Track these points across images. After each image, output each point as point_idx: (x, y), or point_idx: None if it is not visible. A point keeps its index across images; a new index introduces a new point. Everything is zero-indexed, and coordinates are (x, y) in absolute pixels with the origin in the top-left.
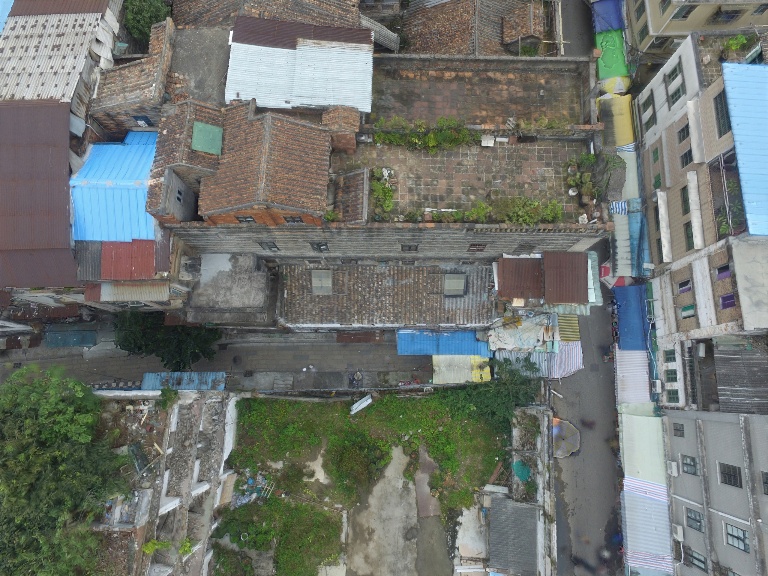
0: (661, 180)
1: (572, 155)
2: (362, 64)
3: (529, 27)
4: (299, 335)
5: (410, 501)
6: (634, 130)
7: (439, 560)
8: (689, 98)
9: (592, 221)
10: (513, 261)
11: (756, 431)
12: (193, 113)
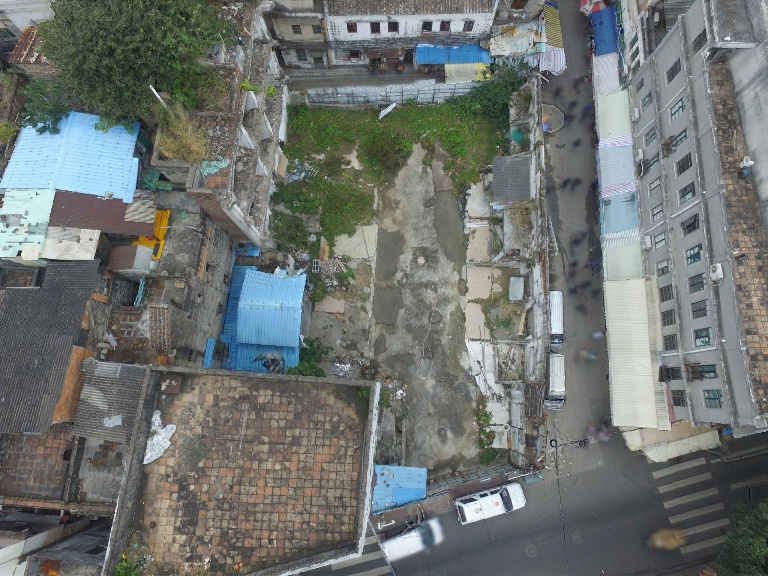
0: None
1: None
2: None
3: None
4: (334, 71)
5: (428, 181)
6: None
7: (452, 221)
8: None
9: None
10: None
11: (689, 18)
12: None
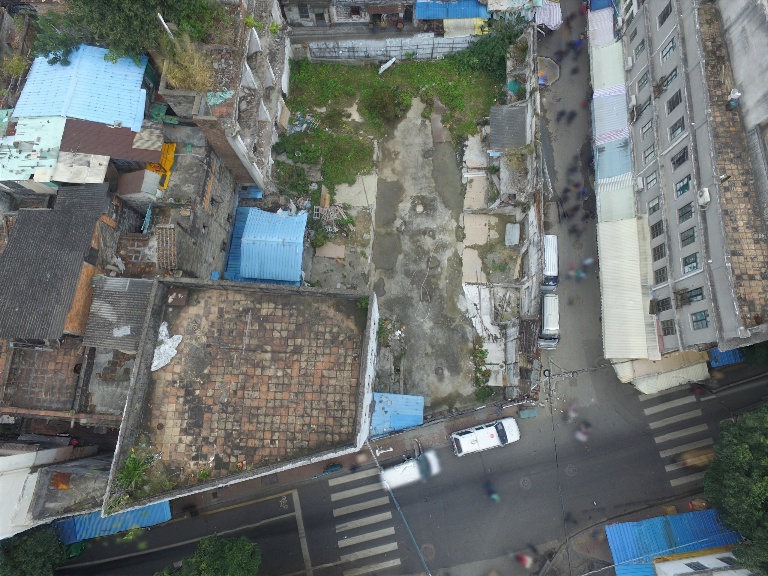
0: None
1: None
2: None
3: None
4: (335, 29)
5: (427, 133)
6: None
7: (450, 171)
8: None
9: None
10: None
11: None
12: None
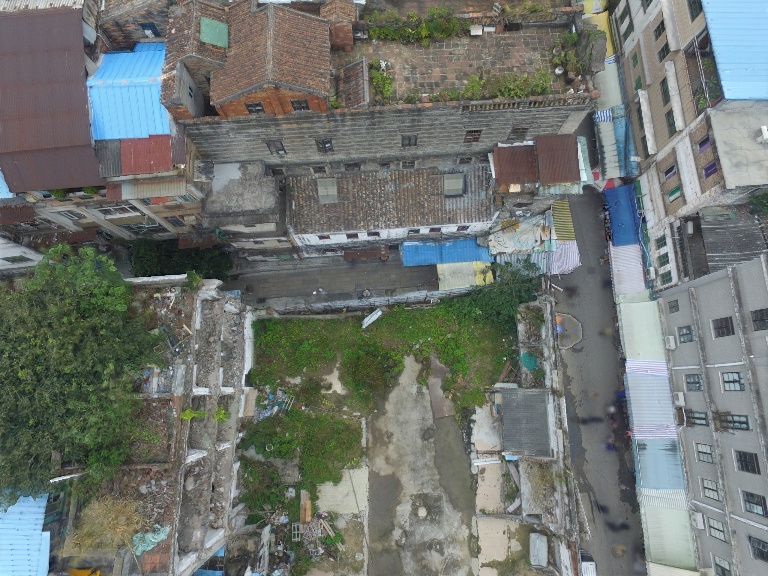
0: (641, 81)
1: None
2: None
3: None
4: (307, 261)
5: (425, 404)
6: (613, 43)
7: (456, 456)
8: None
9: (579, 92)
10: (507, 149)
11: (743, 277)
12: (199, 11)
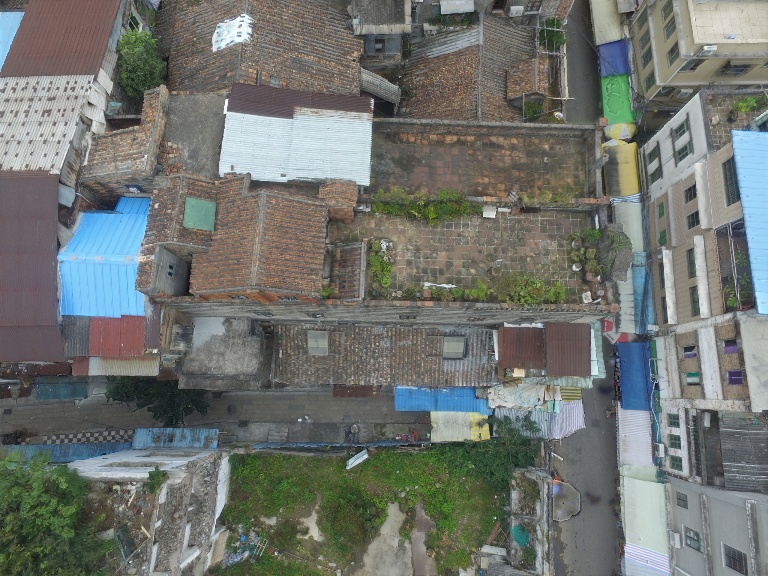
0: (667, 237)
1: (576, 227)
2: (361, 134)
3: (533, 83)
4: (295, 384)
5: (406, 560)
6: (639, 180)
7: None
8: (697, 158)
9: (596, 301)
10: (514, 330)
11: (763, 520)
12: (186, 187)
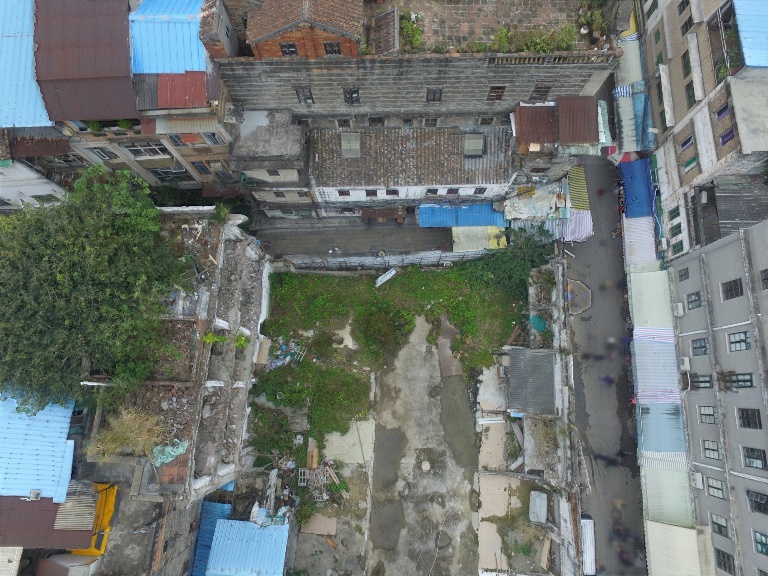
0: (663, 56)
1: None
2: None
3: None
4: (324, 221)
5: (433, 363)
6: (636, 20)
7: (462, 414)
8: None
9: (603, 50)
10: (529, 109)
11: (755, 238)
12: None
